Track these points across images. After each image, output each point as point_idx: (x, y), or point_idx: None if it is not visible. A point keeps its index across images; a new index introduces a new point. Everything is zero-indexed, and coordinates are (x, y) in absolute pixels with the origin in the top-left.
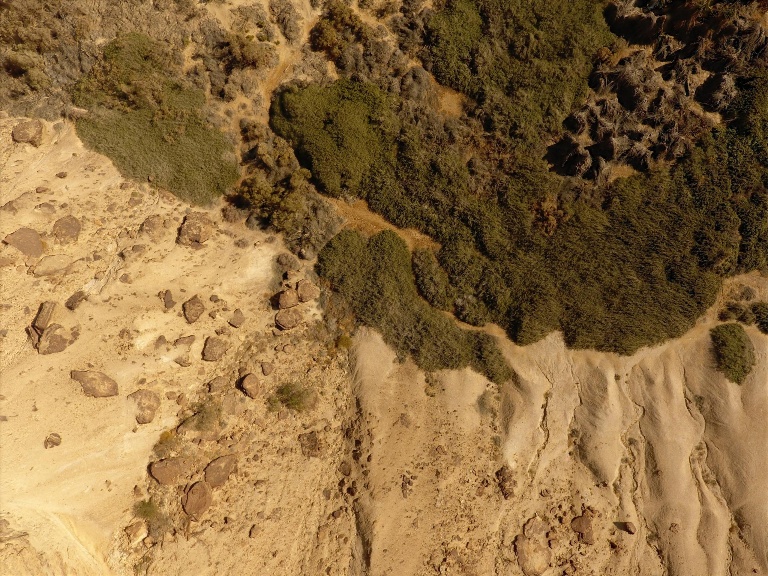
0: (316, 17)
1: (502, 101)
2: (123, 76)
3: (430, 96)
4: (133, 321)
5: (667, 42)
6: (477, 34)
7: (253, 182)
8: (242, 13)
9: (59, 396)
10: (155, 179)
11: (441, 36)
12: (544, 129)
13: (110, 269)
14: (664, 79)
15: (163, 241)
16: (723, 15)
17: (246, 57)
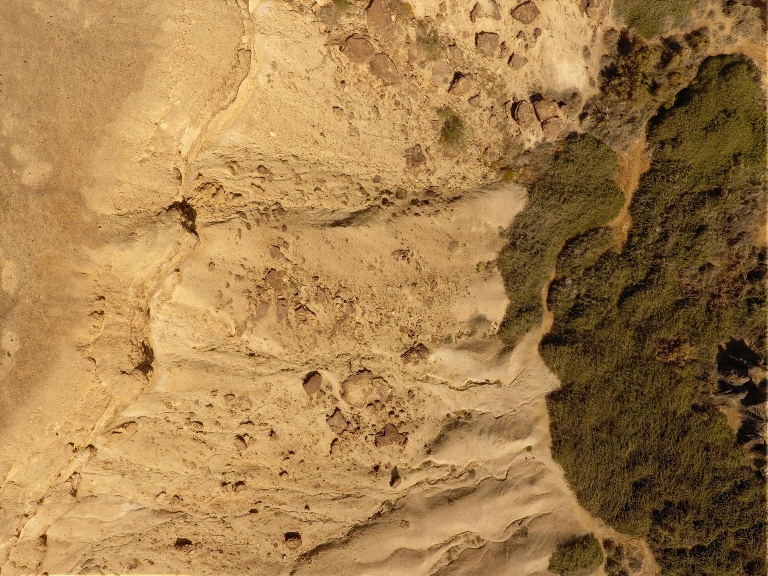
0: None
1: None
2: None
3: None
4: None
5: None
6: None
7: None
8: None
9: None
10: None
11: None
12: (763, 332)
13: None
14: None
15: None
16: None
17: None
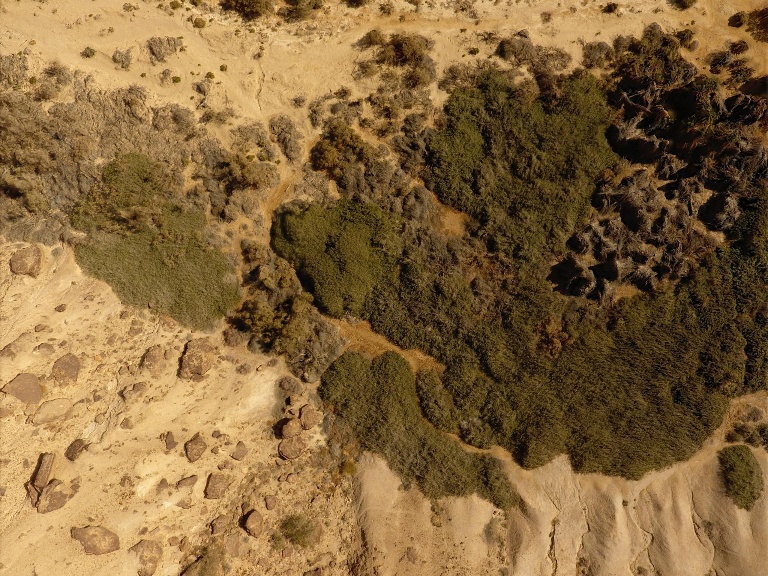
0: (317, 136)
1: (505, 222)
2: (122, 199)
3: (432, 216)
4: (134, 467)
5: (669, 162)
6: (479, 154)
7: (255, 306)
8: (242, 133)
9: (59, 557)
10: (155, 305)
11: (443, 158)
12: (548, 250)
13: (110, 411)
14: (667, 198)
15: (164, 375)
16: (725, 139)
17: (247, 178)
